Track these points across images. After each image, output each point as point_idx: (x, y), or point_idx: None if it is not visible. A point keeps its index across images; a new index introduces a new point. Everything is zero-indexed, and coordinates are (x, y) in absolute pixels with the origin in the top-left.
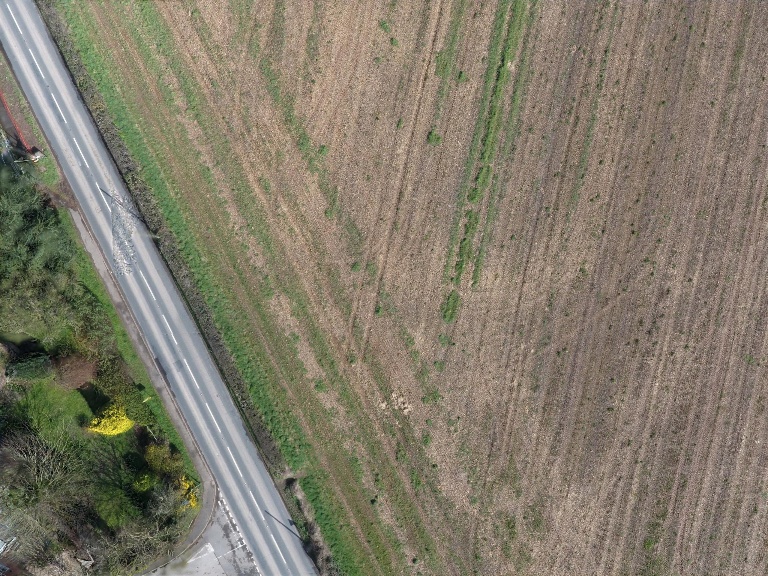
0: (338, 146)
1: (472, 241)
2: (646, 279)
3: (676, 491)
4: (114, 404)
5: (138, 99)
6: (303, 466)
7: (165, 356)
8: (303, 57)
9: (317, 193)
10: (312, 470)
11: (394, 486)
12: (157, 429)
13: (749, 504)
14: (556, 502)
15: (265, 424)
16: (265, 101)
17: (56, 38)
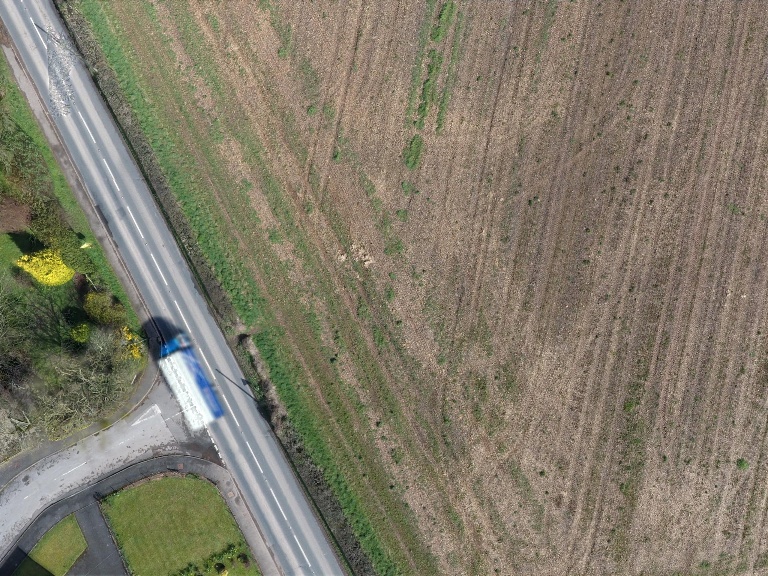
0: None
1: (436, 82)
2: (622, 123)
3: (658, 349)
4: (49, 249)
5: None
6: (257, 322)
7: (106, 203)
8: None
9: (269, 31)
10: (267, 326)
11: (355, 344)
12: (97, 278)
13: (736, 363)
14: (530, 361)
15: (215, 275)
16: None
17: None
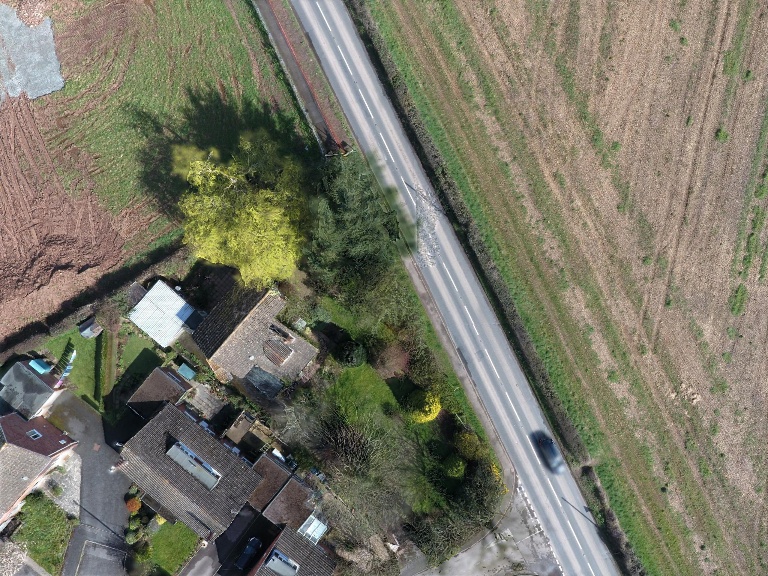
0: (630, 142)
1: (759, 236)
2: None
3: None
4: (428, 392)
5: (439, 95)
6: (597, 454)
7: (467, 346)
8: (597, 55)
9: (610, 188)
10: (606, 458)
11: (683, 474)
12: (464, 417)
13: None
14: None
15: None
16: (560, 98)
17: (370, 35)
